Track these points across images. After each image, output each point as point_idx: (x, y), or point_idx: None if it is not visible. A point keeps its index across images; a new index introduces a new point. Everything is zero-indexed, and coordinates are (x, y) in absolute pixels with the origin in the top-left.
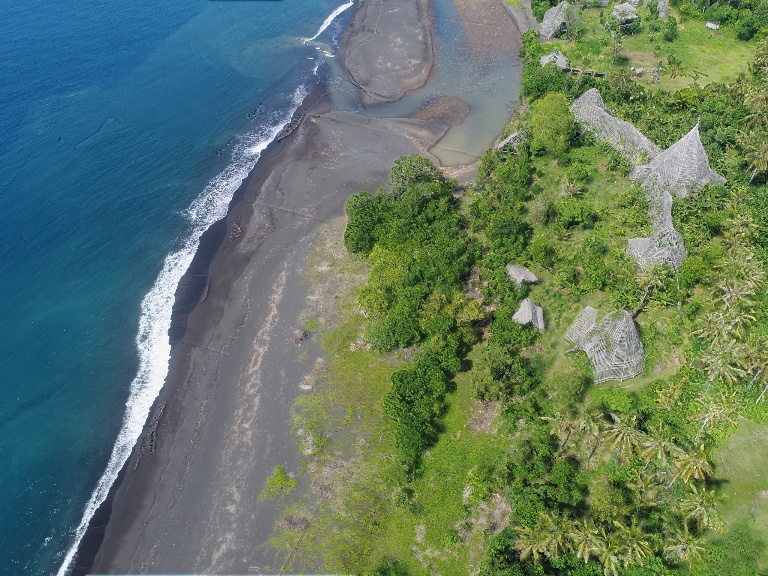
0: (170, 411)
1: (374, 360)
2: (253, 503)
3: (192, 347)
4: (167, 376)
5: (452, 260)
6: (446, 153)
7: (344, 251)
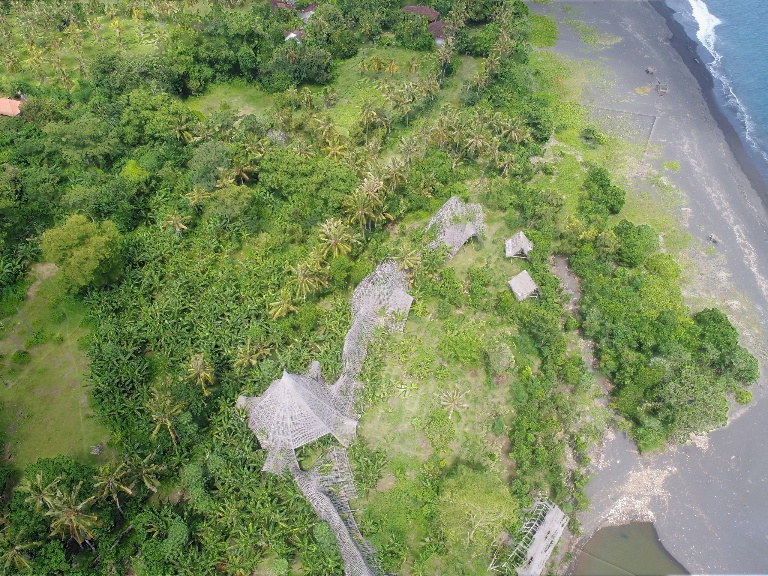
0: None
1: None
2: (682, 160)
3: None
4: None
5: None
6: (653, 568)
7: None
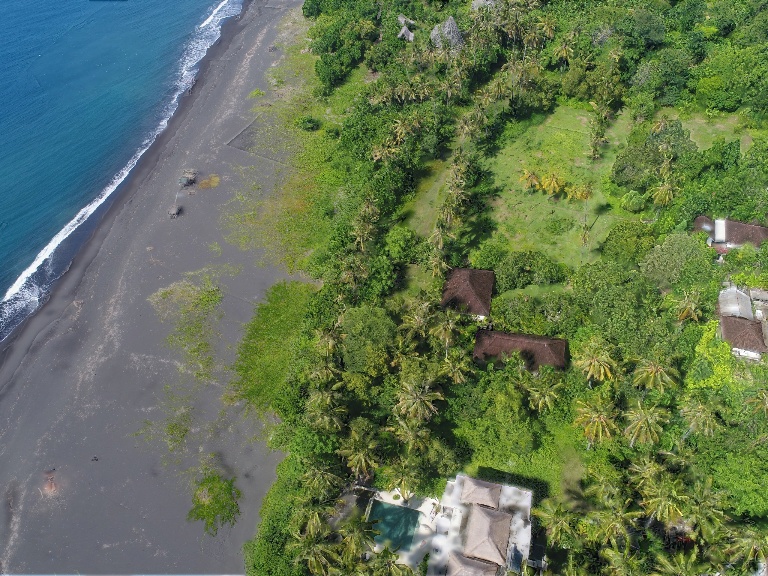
0: (199, 82)
1: (313, 56)
2: (243, 100)
3: (211, 60)
4: (197, 71)
5: (365, 16)
6: None
7: (302, 17)
